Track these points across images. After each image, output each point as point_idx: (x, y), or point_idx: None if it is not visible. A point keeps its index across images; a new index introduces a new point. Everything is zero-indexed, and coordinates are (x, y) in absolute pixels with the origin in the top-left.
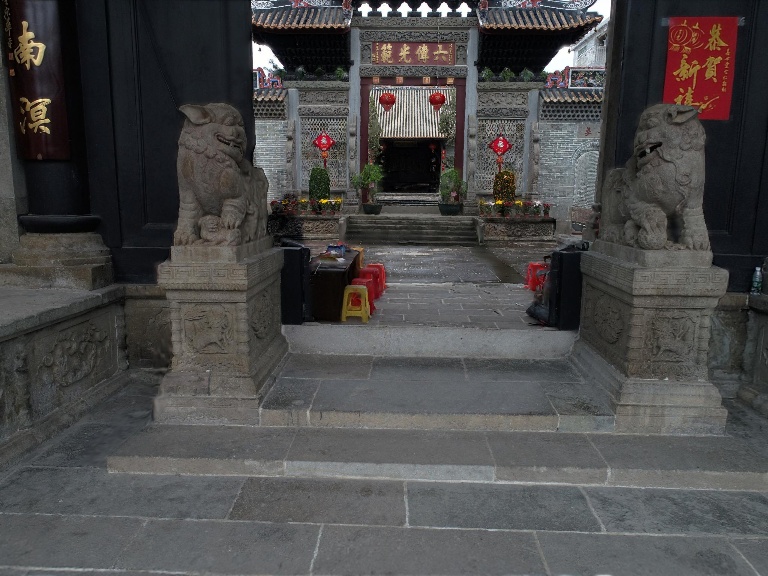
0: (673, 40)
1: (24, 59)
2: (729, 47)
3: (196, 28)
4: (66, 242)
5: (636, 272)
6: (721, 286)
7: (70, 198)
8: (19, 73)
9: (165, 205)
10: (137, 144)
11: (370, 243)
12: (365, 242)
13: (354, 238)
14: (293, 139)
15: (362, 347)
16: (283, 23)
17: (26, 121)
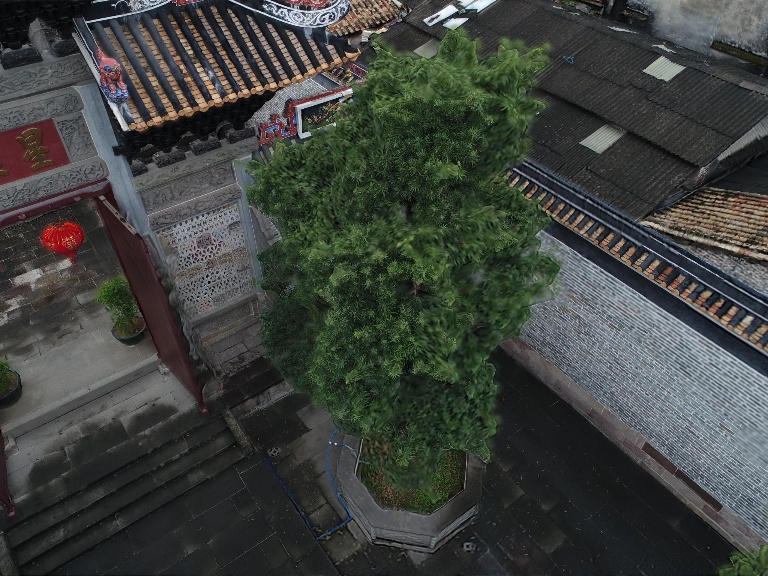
0: None
1: None
2: None
3: None
4: None
5: None
6: None
7: None
8: None
9: None
10: None
11: None
12: None
13: None
14: None
15: None
16: None
17: None
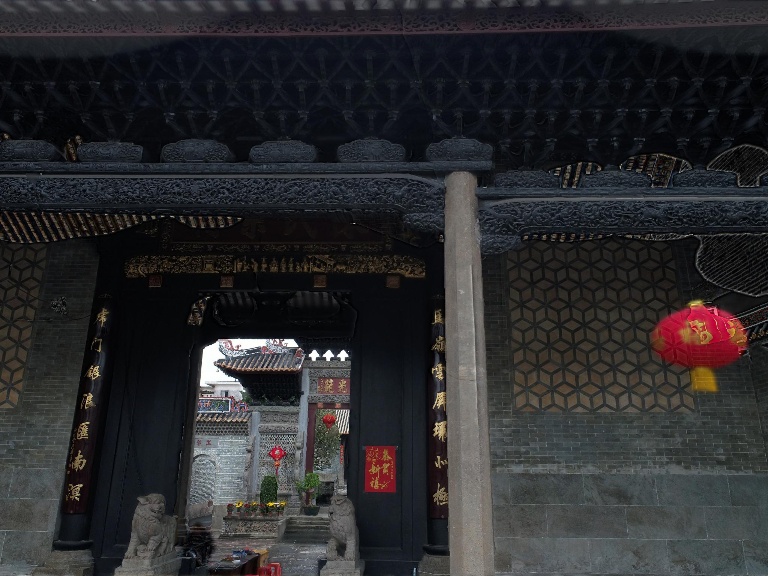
0: (368, 456)
1: (76, 467)
2: (392, 459)
3: (156, 449)
4: (74, 555)
5: (321, 571)
6: None
7: (81, 532)
8: (72, 473)
9: (126, 535)
10: (119, 504)
11: (302, 542)
12: (298, 541)
13: (290, 538)
14: (252, 452)
15: None
16: (251, 367)
17: (69, 495)
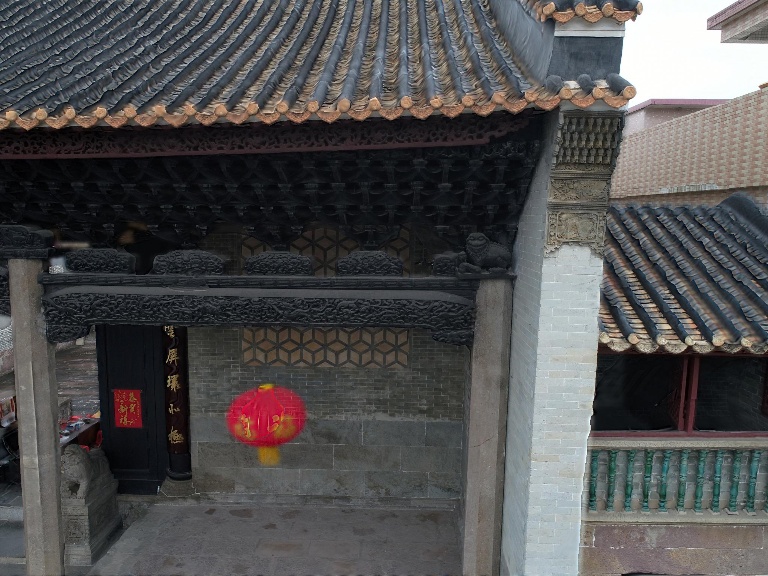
0: (116, 397)
1: None
2: (138, 401)
3: None
4: None
5: None
6: (86, 513)
7: None
8: None
9: None
10: None
11: None
12: None
13: None
14: None
15: (3, 516)
16: None
17: None
